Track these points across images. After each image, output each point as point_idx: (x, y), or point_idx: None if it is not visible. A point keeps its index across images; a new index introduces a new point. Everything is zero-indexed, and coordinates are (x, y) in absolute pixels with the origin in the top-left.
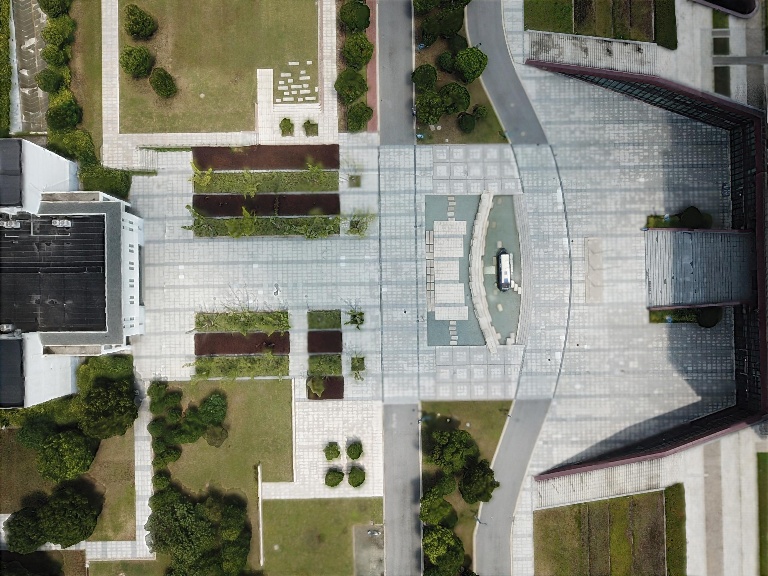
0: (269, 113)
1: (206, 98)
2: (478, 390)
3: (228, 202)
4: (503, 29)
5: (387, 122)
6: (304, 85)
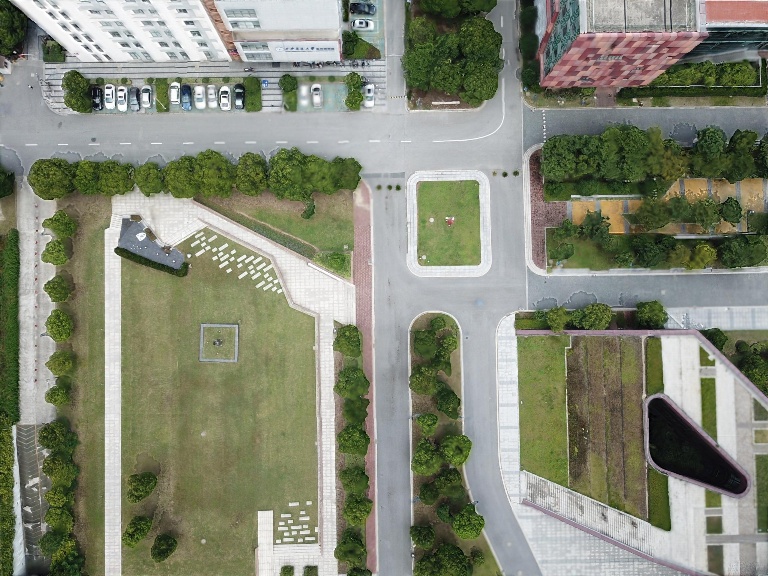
0: (269, 555)
1: (207, 544)
2: None
3: None
4: (500, 468)
5: (386, 562)
6: (304, 525)
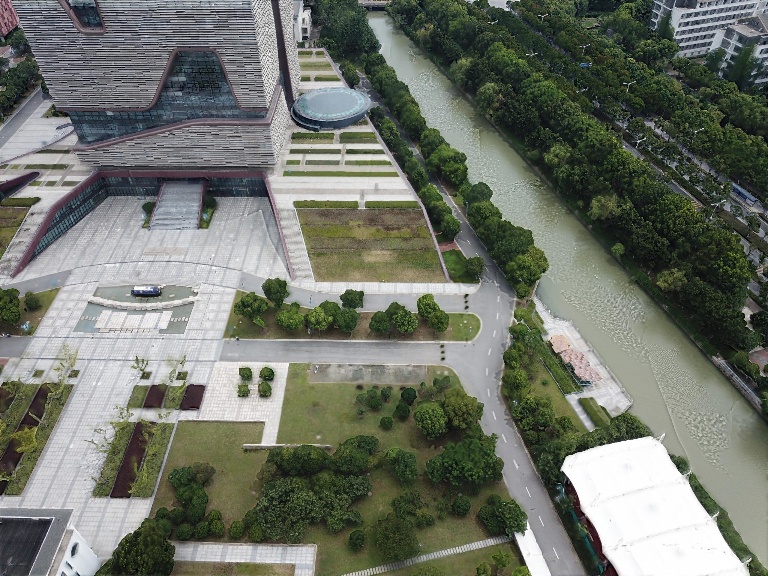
0: None
1: None
2: (225, 307)
3: (4, 463)
4: None
5: (5, 353)
6: None
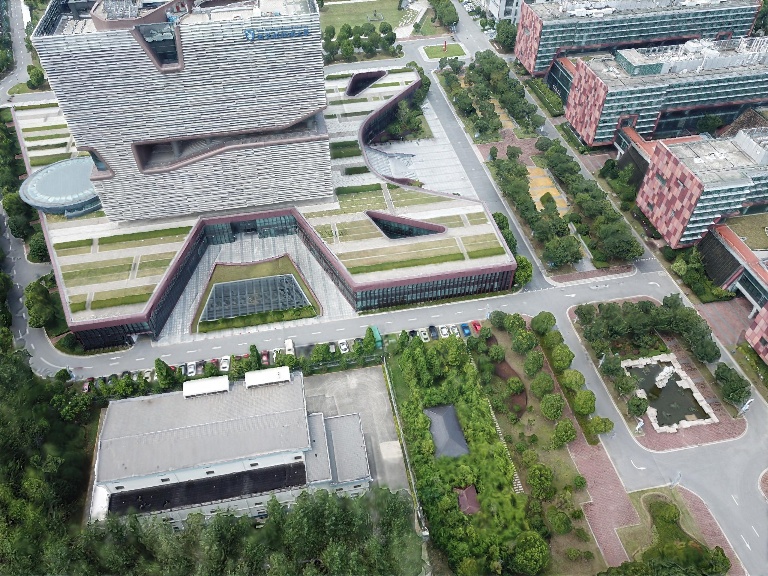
0: None
1: None
2: None
3: None
4: None
5: None
6: None
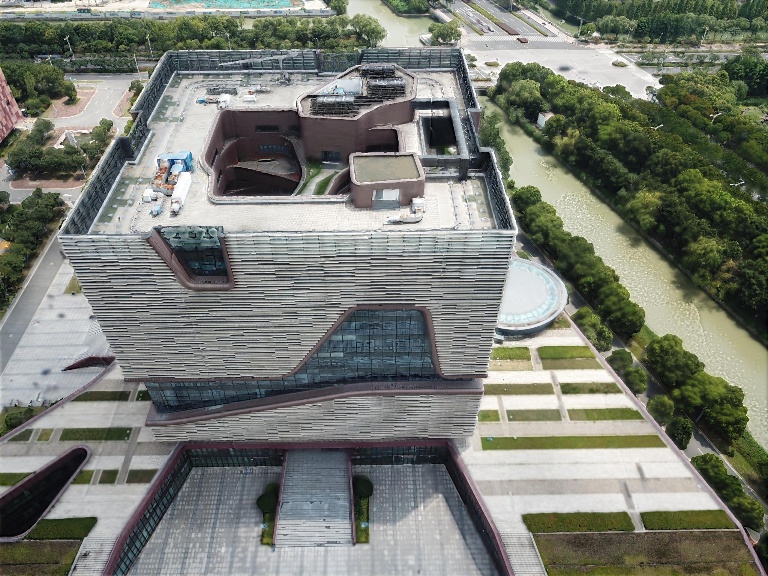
0: None
1: None
2: None
3: None
4: None
5: None
6: None
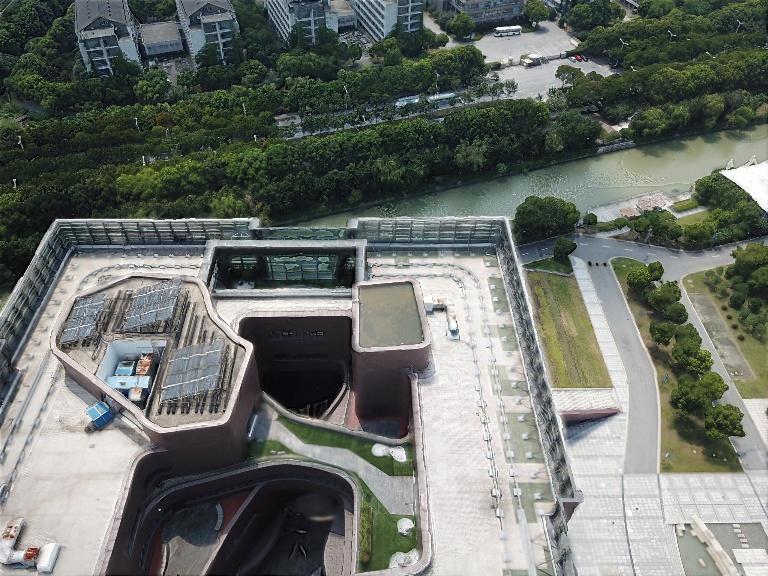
0: None
1: None
2: (695, 482)
3: None
4: None
5: None
6: None
